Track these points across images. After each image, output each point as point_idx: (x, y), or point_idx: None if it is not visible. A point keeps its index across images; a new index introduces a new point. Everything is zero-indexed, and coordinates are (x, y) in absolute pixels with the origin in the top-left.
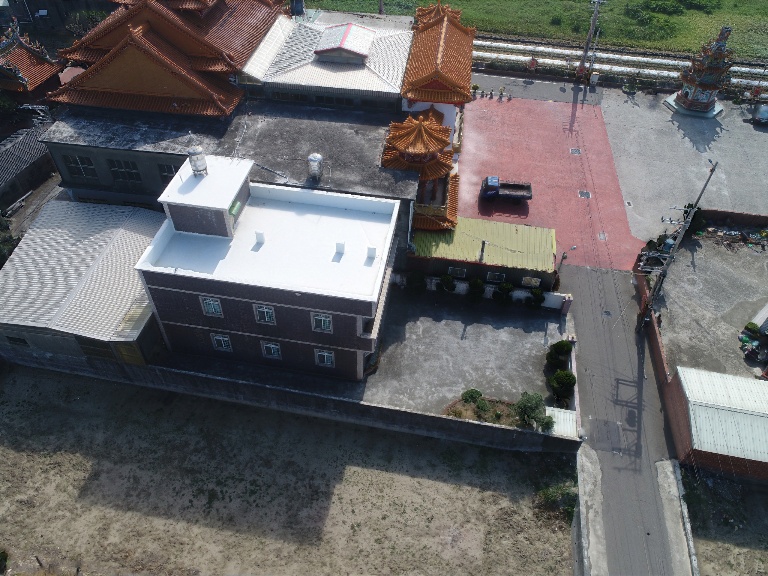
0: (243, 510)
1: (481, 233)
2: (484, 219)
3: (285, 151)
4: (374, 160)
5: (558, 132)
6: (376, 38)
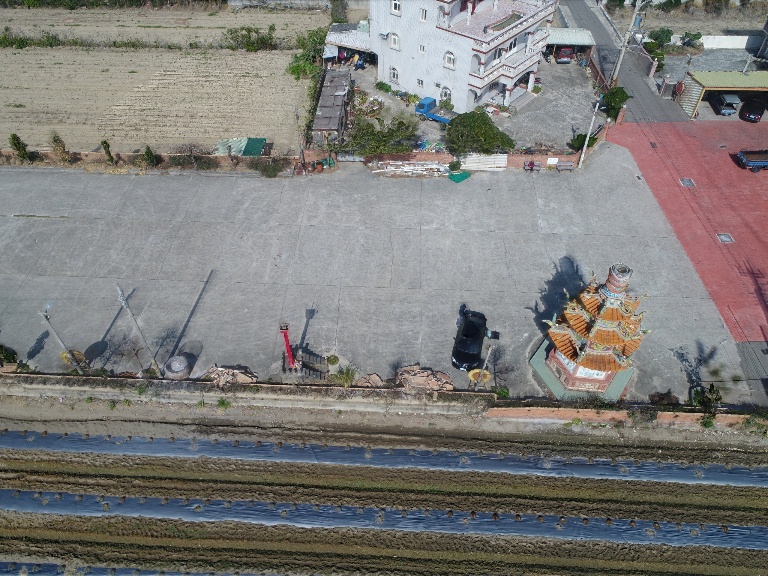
0: (761, 34)
1: (758, 82)
2: (765, 147)
3: None
4: None
5: (767, 268)
6: None
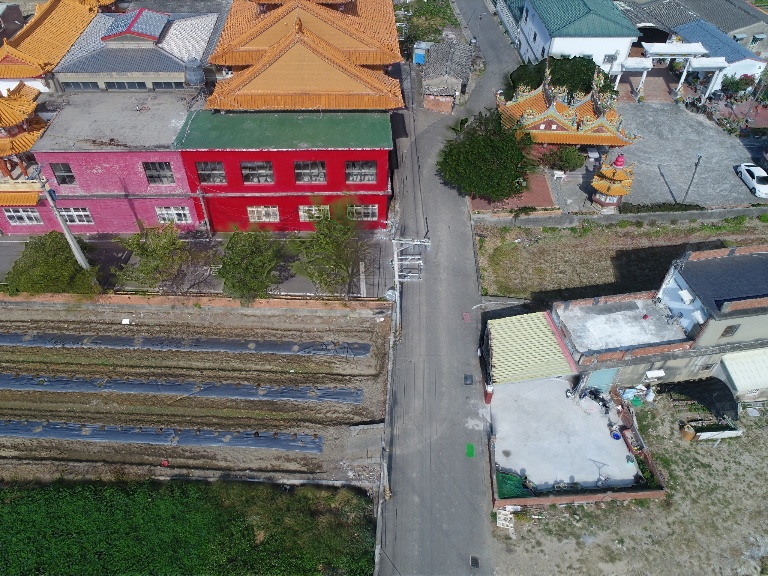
0: None
1: None
2: None
3: (199, 7)
4: (134, 6)
5: None
6: (103, 47)
